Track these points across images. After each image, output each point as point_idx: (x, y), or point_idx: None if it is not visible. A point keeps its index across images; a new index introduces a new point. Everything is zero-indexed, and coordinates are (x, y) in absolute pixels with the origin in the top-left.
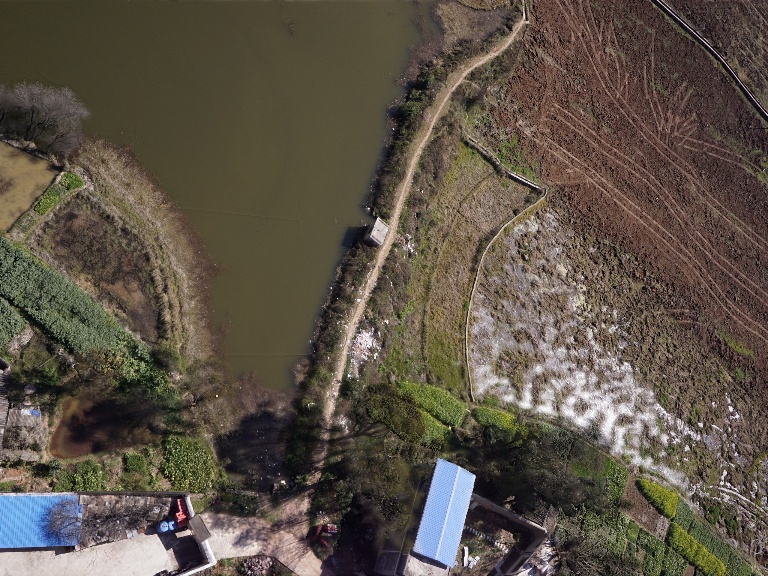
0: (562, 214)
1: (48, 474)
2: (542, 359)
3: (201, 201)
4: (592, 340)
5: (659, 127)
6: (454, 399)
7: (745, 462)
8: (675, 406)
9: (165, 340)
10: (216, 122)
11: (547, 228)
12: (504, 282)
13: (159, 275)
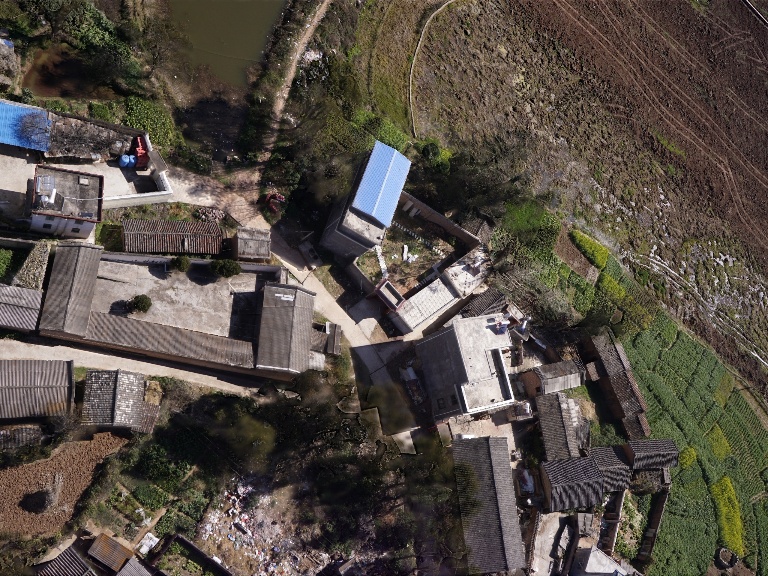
0: (504, 5)
1: None
2: (482, 118)
3: None
4: (530, 113)
5: None
6: (397, 130)
7: (675, 243)
8: (608, 183)
9: None
10: None
11: (489, 14)
12: (447, 49)
13: None
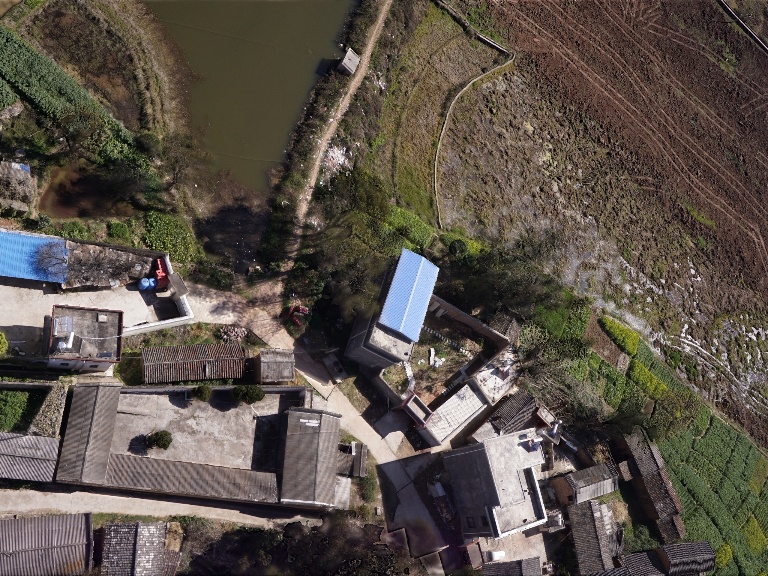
0: (529, 79)
1: (37, 228)
2: (508, 202)
3: (182, 17)
4: (557, 192)
5: (624, 11)
6: (423, 223)
7: (706, 320)
8: (638, 261)
9: (147, 130)
10: None
11: (515, 89)
12: (472, 130)
13: (142, 74)
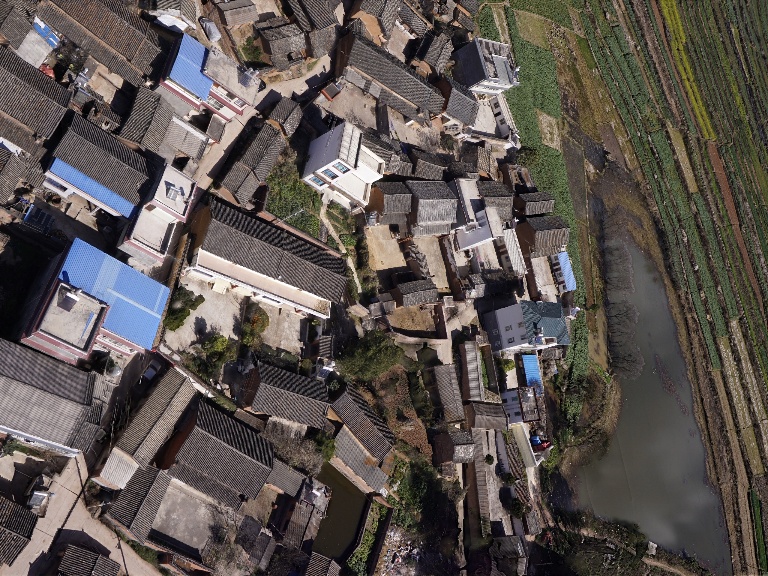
0: None
1: None
2: None
3: (621, 442)
4: None
5: None
6: None
7: None
8: None
9: None
10: (645, 445)
11: None
12: None
13: None
